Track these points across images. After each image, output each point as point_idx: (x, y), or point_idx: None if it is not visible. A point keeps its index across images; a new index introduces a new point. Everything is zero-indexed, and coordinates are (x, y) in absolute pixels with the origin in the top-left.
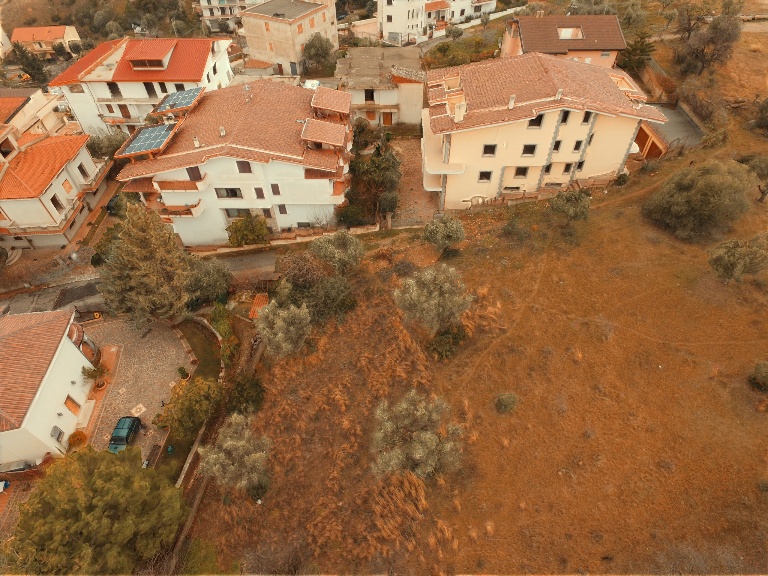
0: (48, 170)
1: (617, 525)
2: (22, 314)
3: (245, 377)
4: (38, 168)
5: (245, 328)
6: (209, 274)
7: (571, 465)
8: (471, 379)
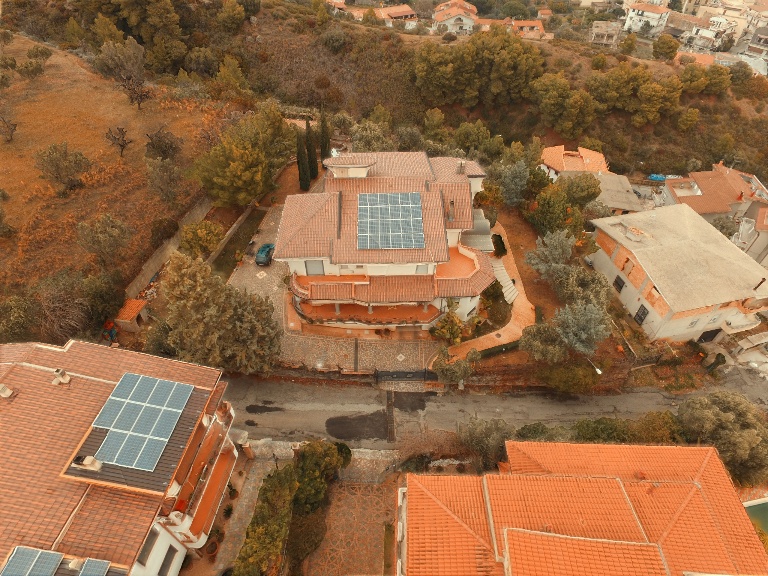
0: (426, 567)
1: (7, 158)
2: (316, 257)
3: (154, 227)
4: (445, 569)
5: (159, 310)
6: (165, 327)
7: (0, 174)
8: (7, 215)
